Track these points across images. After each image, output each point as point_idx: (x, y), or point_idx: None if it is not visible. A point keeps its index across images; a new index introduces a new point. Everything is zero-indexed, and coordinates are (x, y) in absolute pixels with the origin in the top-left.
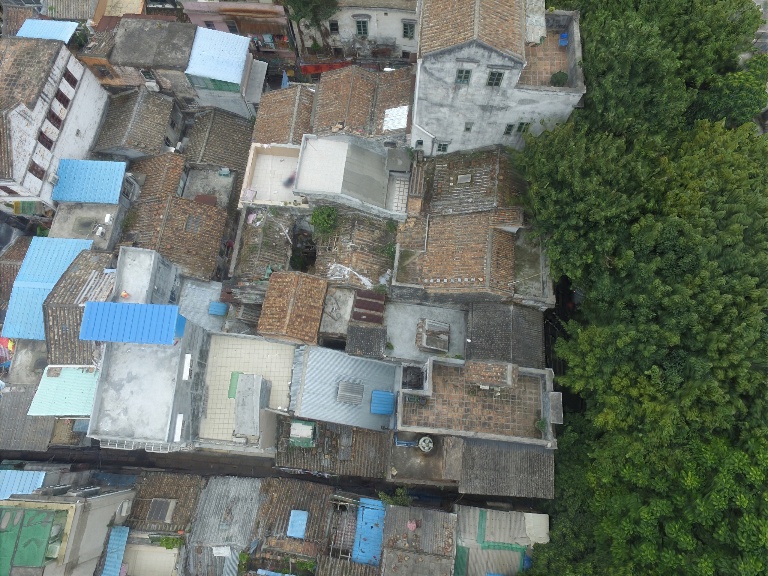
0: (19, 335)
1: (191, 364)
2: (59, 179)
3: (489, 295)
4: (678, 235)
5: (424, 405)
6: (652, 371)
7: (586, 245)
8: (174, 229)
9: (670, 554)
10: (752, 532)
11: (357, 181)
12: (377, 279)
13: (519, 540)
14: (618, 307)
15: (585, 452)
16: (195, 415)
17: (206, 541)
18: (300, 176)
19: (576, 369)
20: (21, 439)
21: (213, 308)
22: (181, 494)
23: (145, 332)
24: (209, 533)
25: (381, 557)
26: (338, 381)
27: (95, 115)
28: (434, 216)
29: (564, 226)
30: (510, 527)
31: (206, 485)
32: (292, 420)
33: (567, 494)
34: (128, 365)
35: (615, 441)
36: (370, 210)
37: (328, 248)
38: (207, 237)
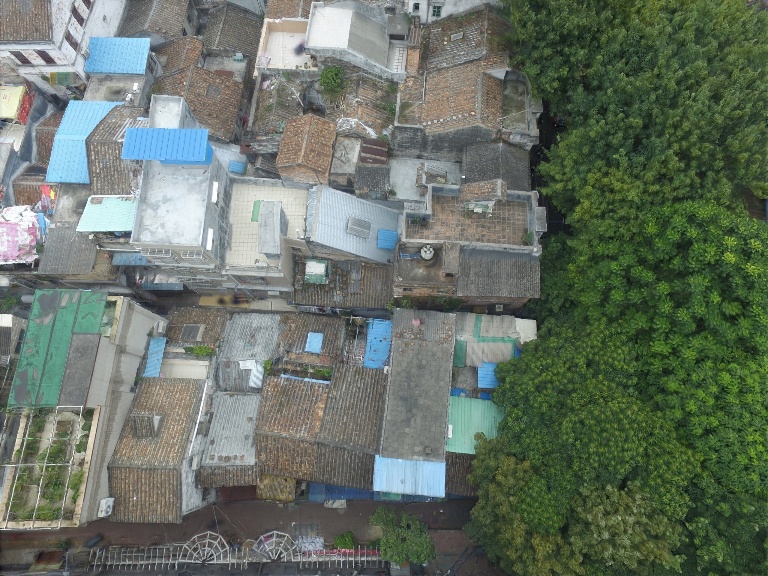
0: (62, 179)
1: (218, 195)
2: (90, 54)
3: (480, 131)
4: (640, 41)
5: (425, 226)
6: (619, 155)
7: (563, 59)
8: (196, 94)
9: (635, 292)
10: (700, 254)
11: (361, 43)
12: (381, 131)
13: (510, 334)
14: (591, 114)
15: (567, 261)
16: (222, 243)
17: (233, 357)
18: (310, 37)
19: (557, 175)
20: (67, 265)
21: (233, 166)
22: (209, 322)
23: (179, 151)
24: (236, 352)
25: (390, 350)
26: (348, 218)
27: (118, 7)
28: (430, 71)
29: (543, 44)
30: (502, 326)
31: (231, 319)
32: (307, 259)
33: (552, 297)
34: (163, 190)
35: (590, 225)
36: (373, 69)
37: (336, 106)
38: (226, 104)
